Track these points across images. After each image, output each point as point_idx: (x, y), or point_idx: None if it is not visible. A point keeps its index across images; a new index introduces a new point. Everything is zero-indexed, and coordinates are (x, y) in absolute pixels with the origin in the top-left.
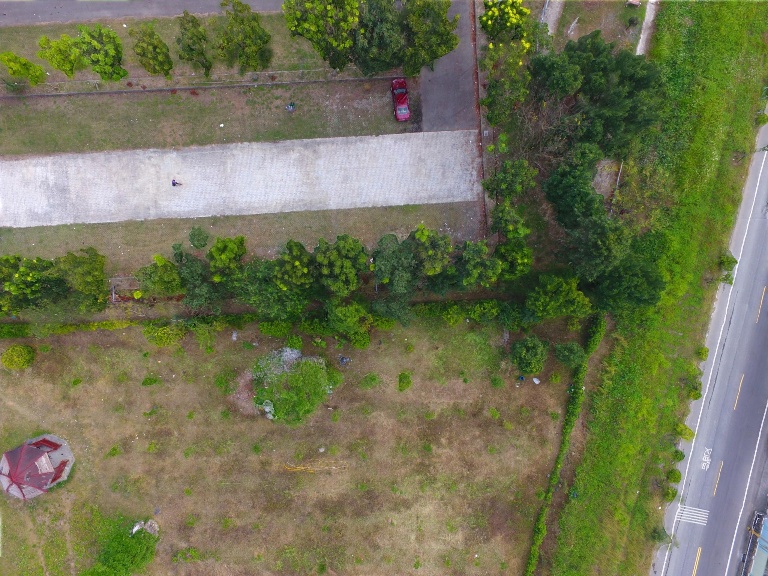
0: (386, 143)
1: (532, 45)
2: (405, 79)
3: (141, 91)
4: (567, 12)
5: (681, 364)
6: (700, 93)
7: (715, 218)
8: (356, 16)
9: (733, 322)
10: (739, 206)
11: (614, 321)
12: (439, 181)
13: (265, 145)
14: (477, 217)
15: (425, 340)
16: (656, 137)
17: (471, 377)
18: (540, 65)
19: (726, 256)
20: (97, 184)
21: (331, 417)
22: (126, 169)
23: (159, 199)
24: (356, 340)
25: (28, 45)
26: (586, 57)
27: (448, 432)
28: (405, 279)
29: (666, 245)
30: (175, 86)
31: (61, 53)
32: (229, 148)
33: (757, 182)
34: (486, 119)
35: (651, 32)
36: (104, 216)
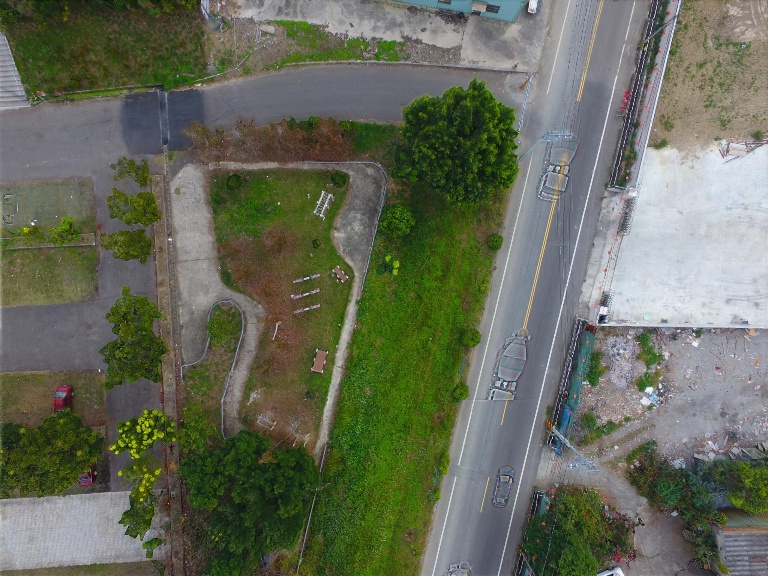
0: (73, 503)
1: (185, 446)
2: None
3: None
4: (253, 376)
5: None
6: (371, 472)
7: None
8: None
9: None
10: (417, 575)
11: None
12: (127, 540)
13: None
14: (165, 575)
15: None
16: (338, 503)
17: None
18: None
19: None
20: None
21: None
22: None
23: None
24: None
25: None
26: None
27: None
28: None
29: None
30: None
31: None
32: None
33: (437, 549)
34: (173, 480)
35: (337, 395)
36: None
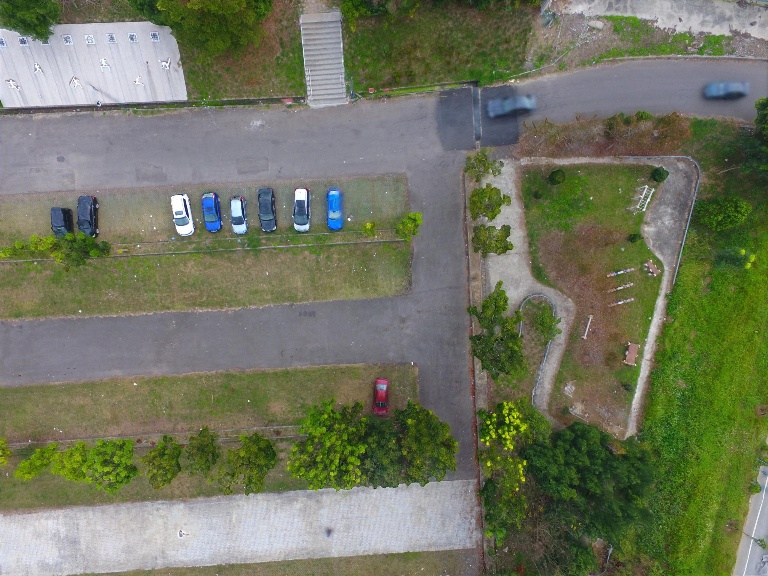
0: (387, 493)
1: (529, 437)
2: None
3: (150, 446)
4: (564, 369)
5: None
6: (694, 463)
7: None
8: (358, 477)
9: None
10: (733, 566)
11: None
12: (439, 529)
13: (270, 496)
14: (476, 564)
15: None
16: (651, 494)
17: None
18: (537, 466)
19: None
20: (106, 535)
21: None
22: (135, 521)
23: (166, 549)
24: None
25: (42, 404)
26: (581, 461)
27: None
28: None
29: None
30: (183, 442)
31: (74, 470)
32: (235, 499)
33: (751, 540)
34: None
35: (646, 387)
36: (113, 566)
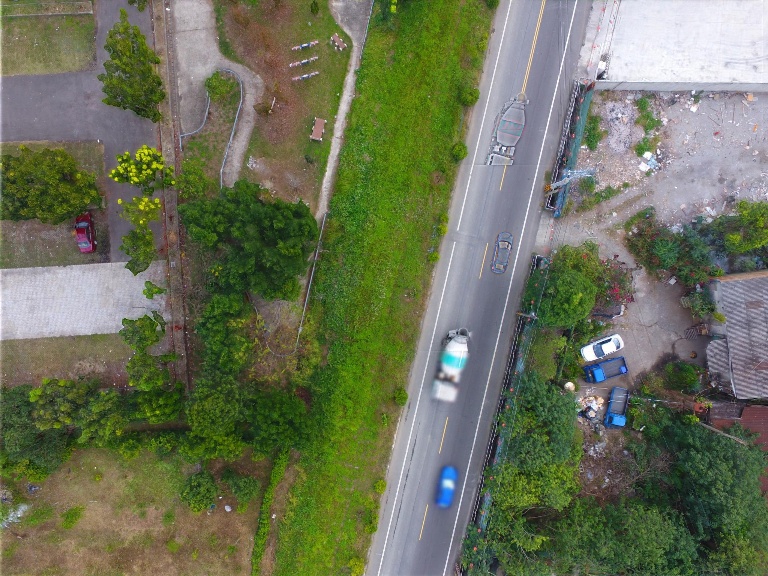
0: (74, 273)
1: (184, 191)
2: (92, 211)
3: None
4: (252, 146)
5: (356, 498)
6: (370, 231)
7: (386, 354)
8: None
9: (416, 453)
10: (417, 340)
11: (299, 451)
12: (127, 311)
13: None
14: (166, 346)
15: (114, 468)
16: (337, 270)
17: (163, 505)
18: (183, 215)
19: (399, 391)
20: None
21: (20, 545)
22: None
23: None
24: (30, 474)
25: None
26: (227, 208)
27: (140, 559)
28: (20, 437)
29: (338, 380)
30: None
31: None
32: None
33: (437, 315)
34: (173, 250)
35: (336, 165)
36: None
